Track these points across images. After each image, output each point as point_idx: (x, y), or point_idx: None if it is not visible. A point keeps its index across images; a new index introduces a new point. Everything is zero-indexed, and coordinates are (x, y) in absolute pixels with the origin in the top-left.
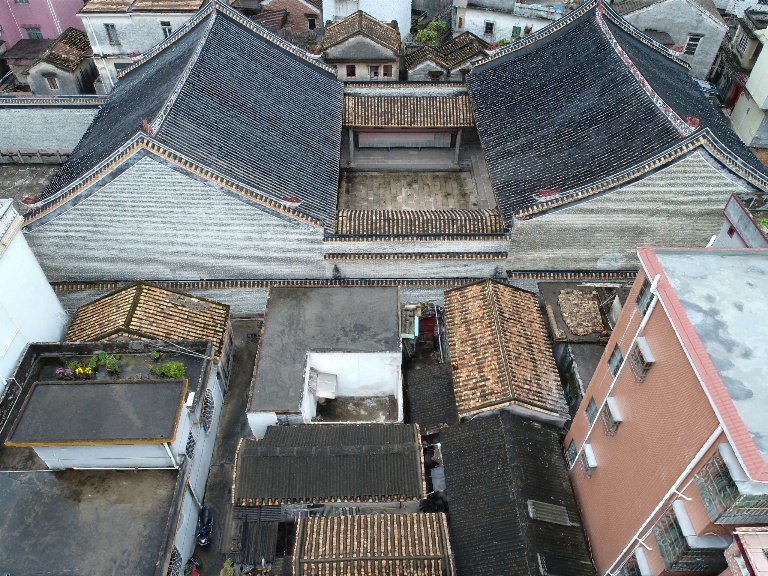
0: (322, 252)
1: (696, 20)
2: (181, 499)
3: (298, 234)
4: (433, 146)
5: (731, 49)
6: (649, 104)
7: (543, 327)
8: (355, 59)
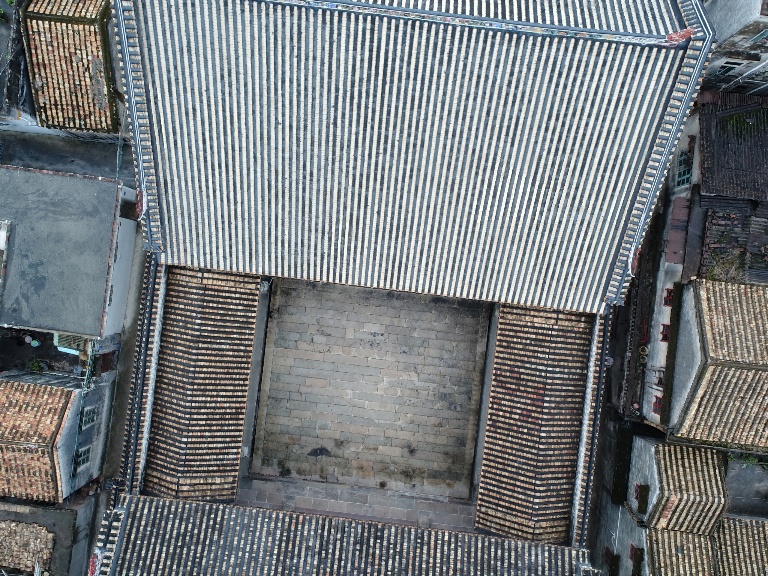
0: None
1: None
2: None
3: None
4: None
5: None
6: None
7: (3, 493)
8: (677, 344)
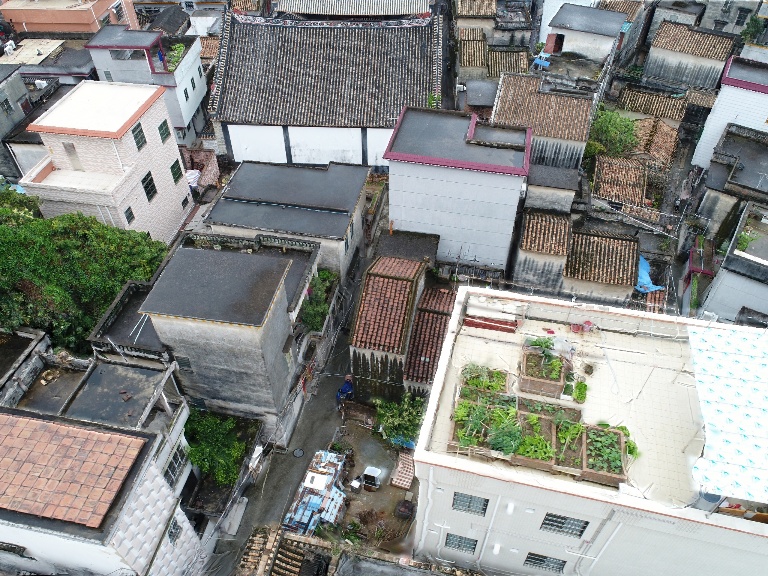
0: None
1: None
2: (167, 1)
3: None
4: None
5: None
6: None
7: None
8: None
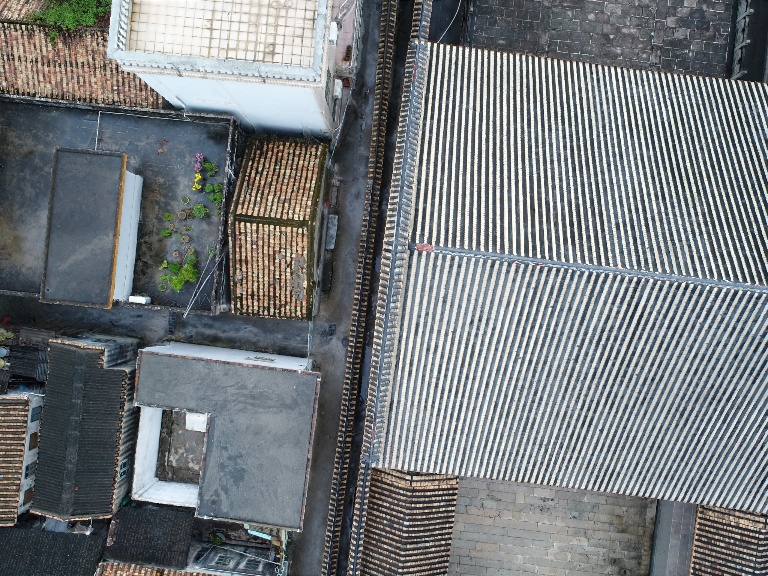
0: None
1: None
2: None
3: None
4: None
5: None
6: None
7: None
8: None
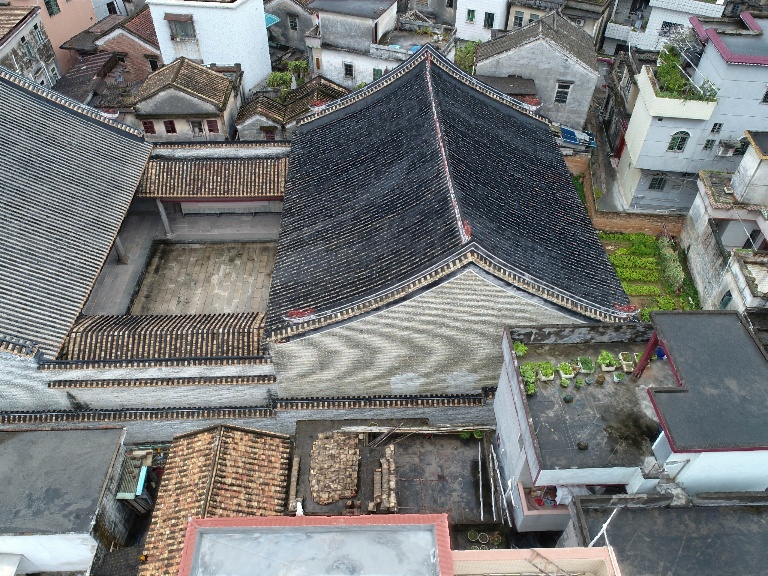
0: (44, 380)
1: (563, 66)
2: None
3: (4, 363)
4: (268, 211)
5: (620, 91)
6: (446, 192)
7: (281, 491)
8: (172, 114)
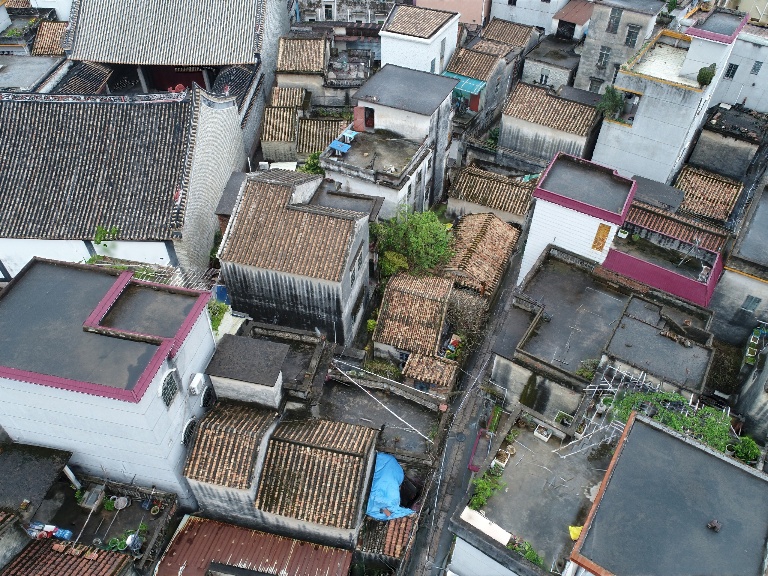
0: None
1: None
2: None
3: None
4: None
5: None
6: None
7: None
8: None
